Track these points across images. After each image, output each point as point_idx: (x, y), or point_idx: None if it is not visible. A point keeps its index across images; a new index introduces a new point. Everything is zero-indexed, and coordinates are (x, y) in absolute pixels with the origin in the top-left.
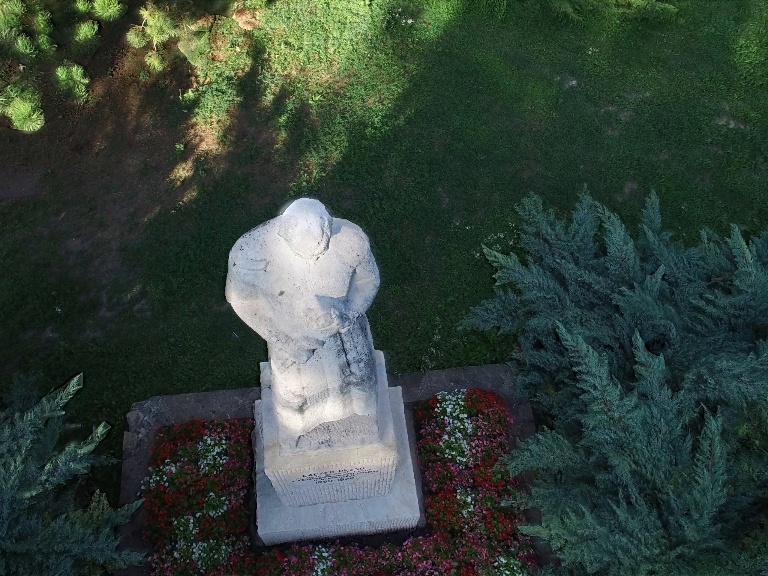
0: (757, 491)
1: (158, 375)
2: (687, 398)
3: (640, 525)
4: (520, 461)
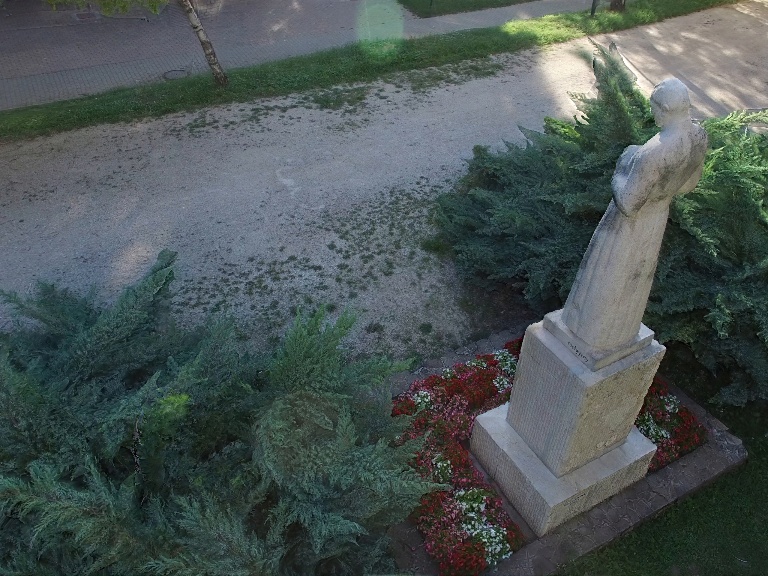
0: (207, 479)
1: (760, 491)
2: (279, 533)
3: (318, 407)
4: (422, 440)
